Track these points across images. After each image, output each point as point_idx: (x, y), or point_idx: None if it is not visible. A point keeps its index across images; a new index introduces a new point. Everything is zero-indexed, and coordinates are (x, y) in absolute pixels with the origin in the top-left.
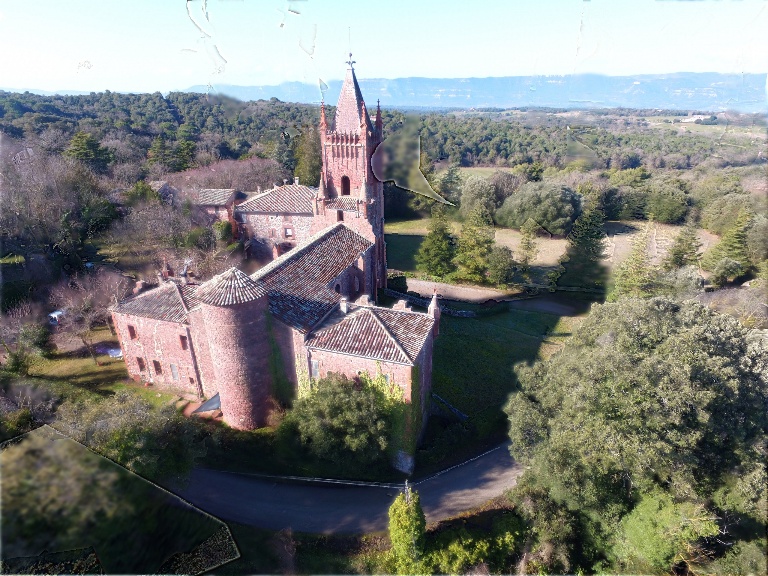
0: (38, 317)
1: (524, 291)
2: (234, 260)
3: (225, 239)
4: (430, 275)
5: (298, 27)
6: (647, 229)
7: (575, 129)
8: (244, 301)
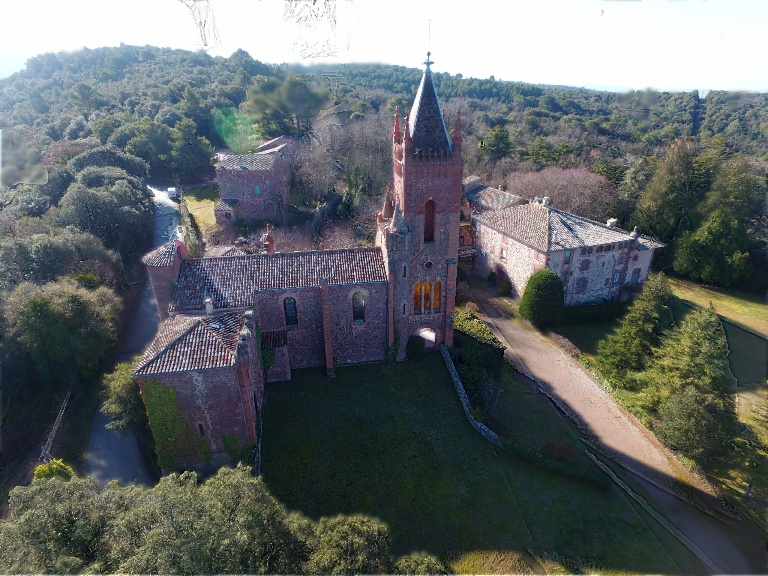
0: None
1: (720, 497)
2: None
3: None
4: None
5: (619, 12)
6: None
7: None
8: (148, 264)
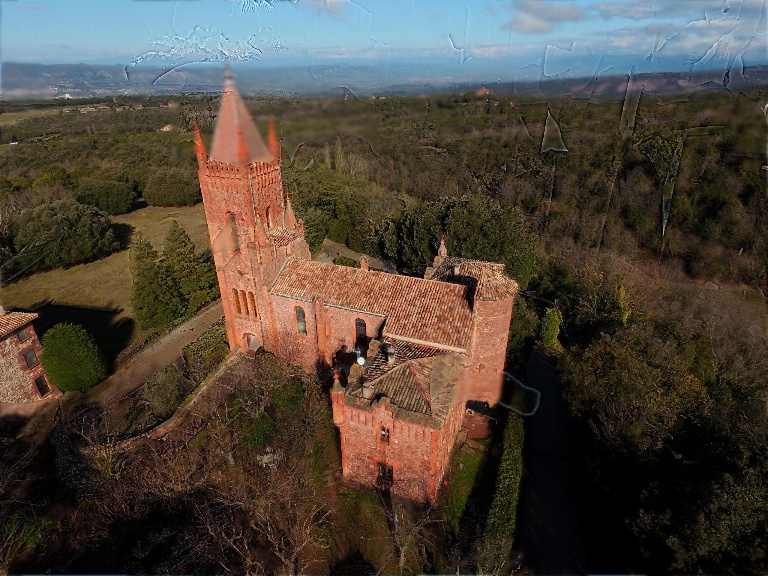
0: None
1: None
2: None
3: None
4: (172, 322)
5: None
6: (292, 192)
7: (38, 137)
8: None
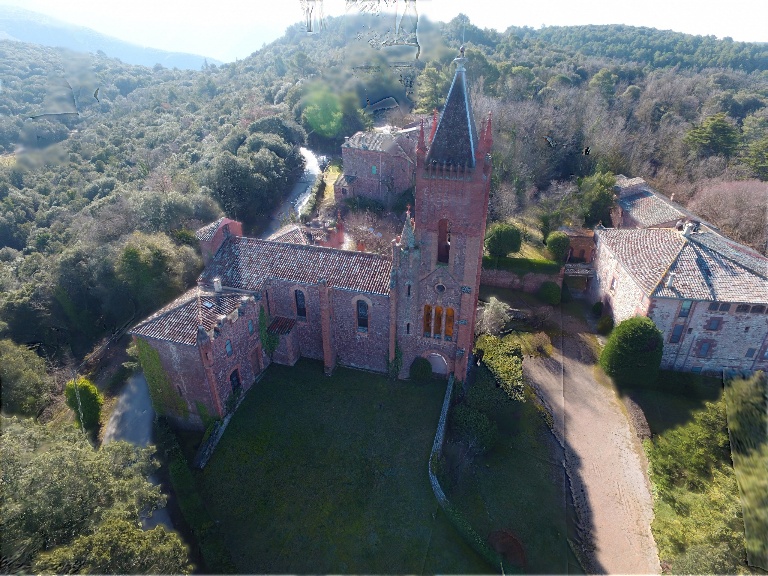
0: (373, 227)
1: None
2: (532, 274)
3: (550, 252)
4: None
5: None
6: None
7: None
8: None
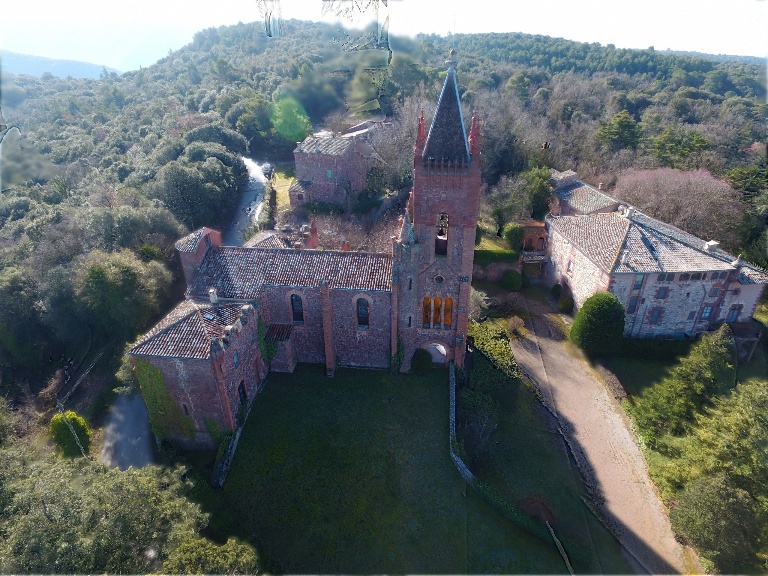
0: None
1: None
2: (494, 264)
3: (508, 242)
4: None
5: None
6: None
7: None
8: (177, 248)
